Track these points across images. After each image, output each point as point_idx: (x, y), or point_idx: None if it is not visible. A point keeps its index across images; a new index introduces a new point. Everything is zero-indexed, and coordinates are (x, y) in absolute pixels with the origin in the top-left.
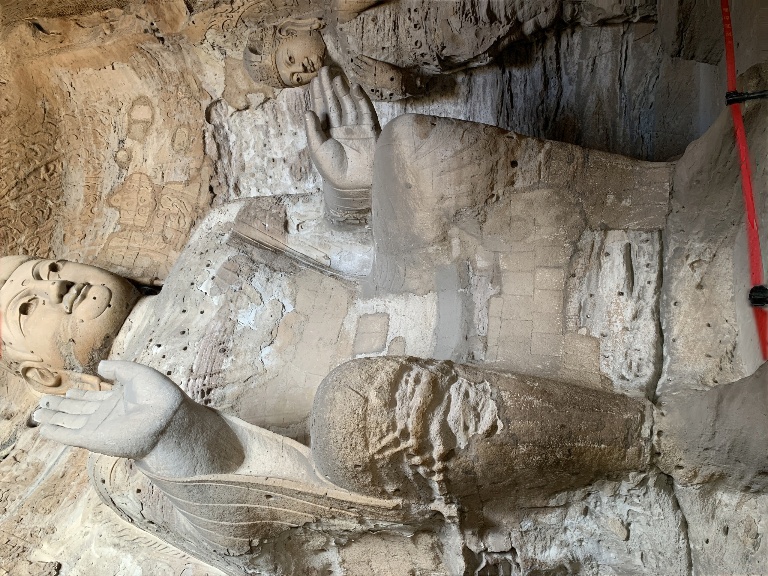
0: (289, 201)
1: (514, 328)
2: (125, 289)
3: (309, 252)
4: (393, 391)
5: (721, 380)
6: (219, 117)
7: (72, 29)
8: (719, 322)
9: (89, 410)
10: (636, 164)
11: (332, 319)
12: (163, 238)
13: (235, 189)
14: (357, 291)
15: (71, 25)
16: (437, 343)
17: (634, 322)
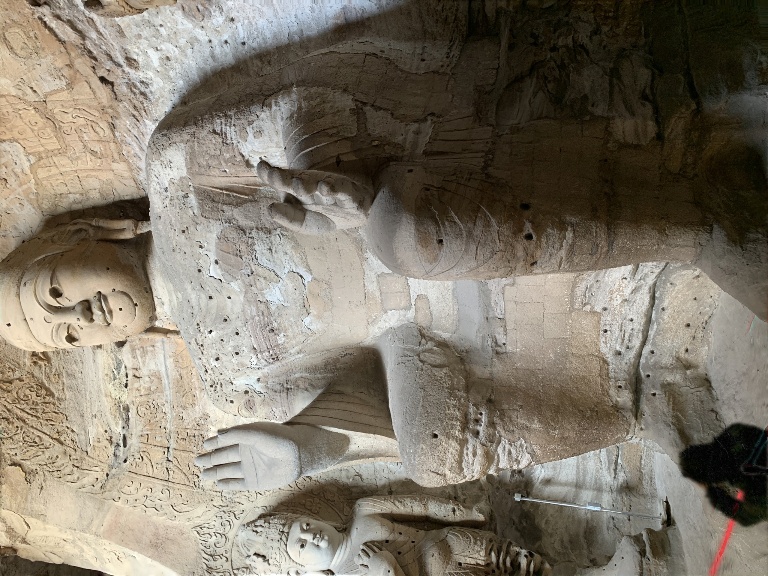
0: (237, 137)
1: (528, 311)
2: (132, 278)
3: None
4: (460, 464)
5: (691, 350)
6: None
7: None
8: (704, 298)
9: (234, 460)
10: (663, 241)
11: (353, 282)
12: (92, 154)
13: (129, 64)
14: (363, 240)
15: None
16: (459, 308)
17: (632, 295)
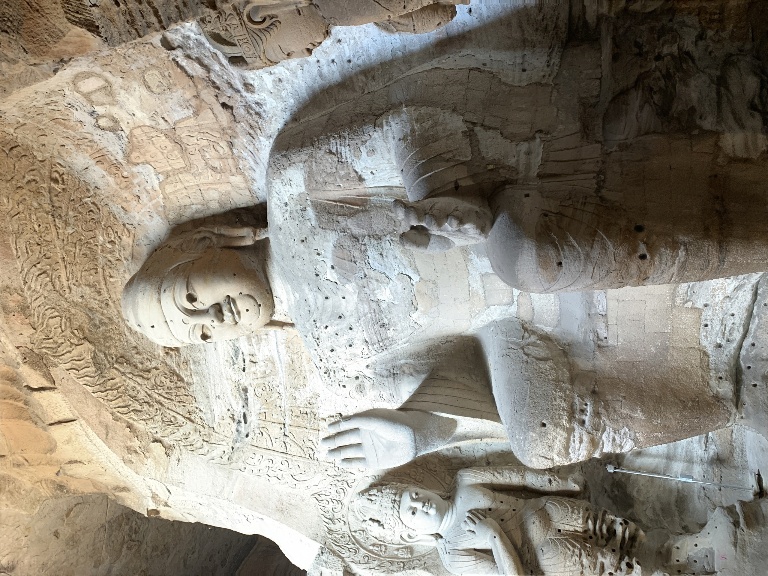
0: (351, 156)
1: (630, 308)
2: (255, 282)
3: (390, 181)
4: (567, 450)
5: None
6: (177, 32)
7: None
8: None
9: (355, 442)
10: None
11: (458, 281)
12: (213, 170)
13: (247, 89)
14: None
15: None
16: (560, 304)
17: (734, 293)
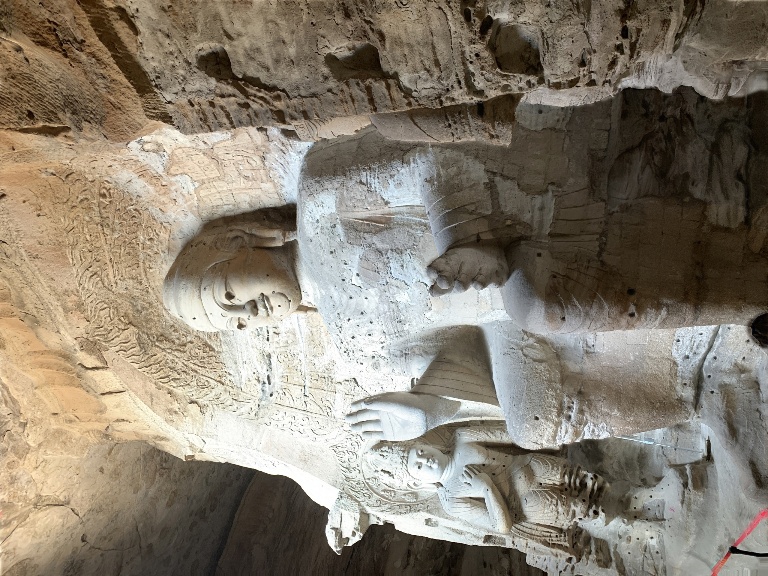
0: (380, 187)
1: None
2: (286, 281)
3: (412, 201)
4: (554, 438)
5: (747, 359)
6: None
7: (8, 134)
8: None
9: None
10: (738, 315)
11: (469, 290)
12: (245, 179)
13: None
14: None
15: (3, 134)
16: None
17: None
